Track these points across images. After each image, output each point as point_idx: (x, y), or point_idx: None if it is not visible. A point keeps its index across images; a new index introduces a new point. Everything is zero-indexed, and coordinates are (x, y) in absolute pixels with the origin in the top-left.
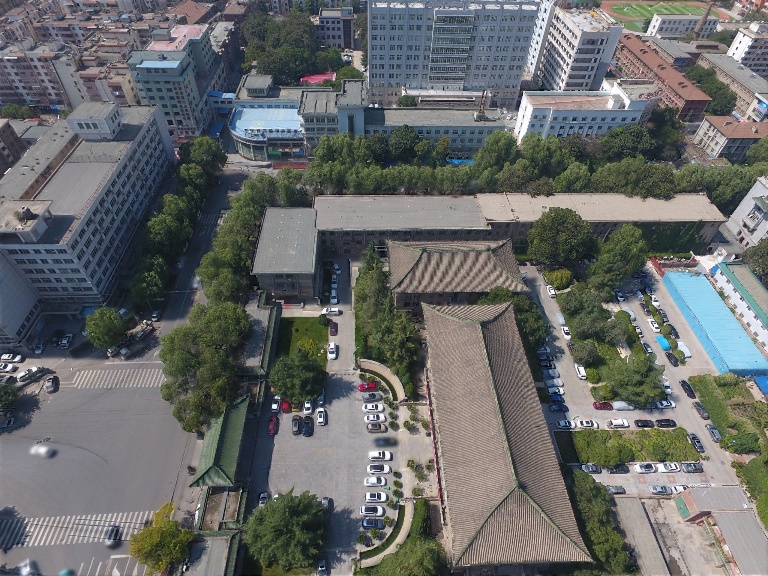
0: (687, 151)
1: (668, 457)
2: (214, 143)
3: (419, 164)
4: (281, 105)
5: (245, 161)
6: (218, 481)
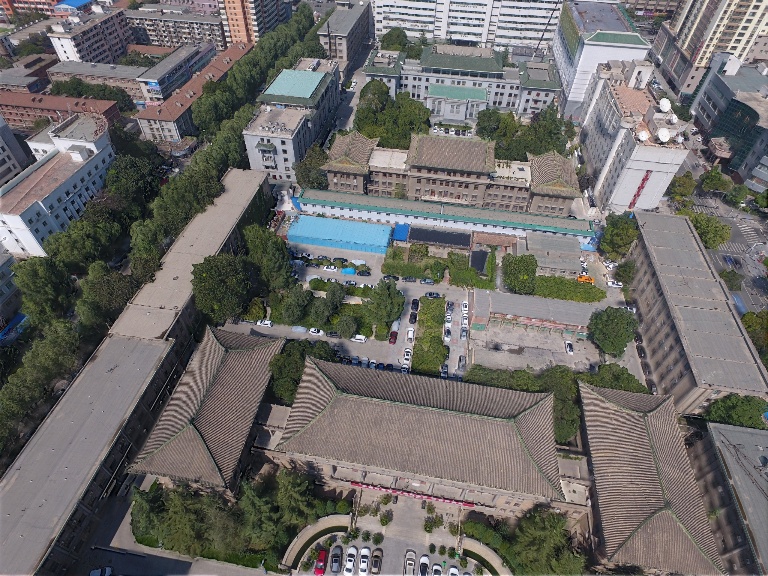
0: (159, 150)
1: None
2: None
3: None
4: None
5: None
6: None
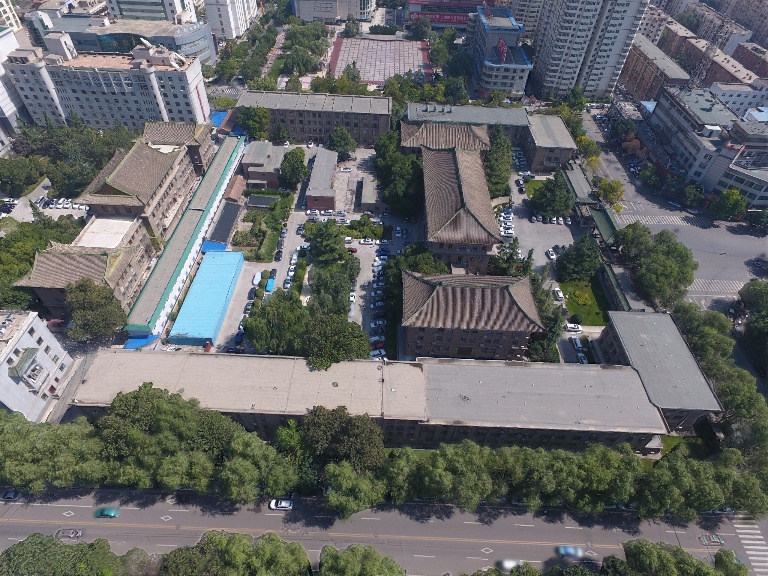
0: None
1: None
2: None
3: None
4: None
5: None
6: None
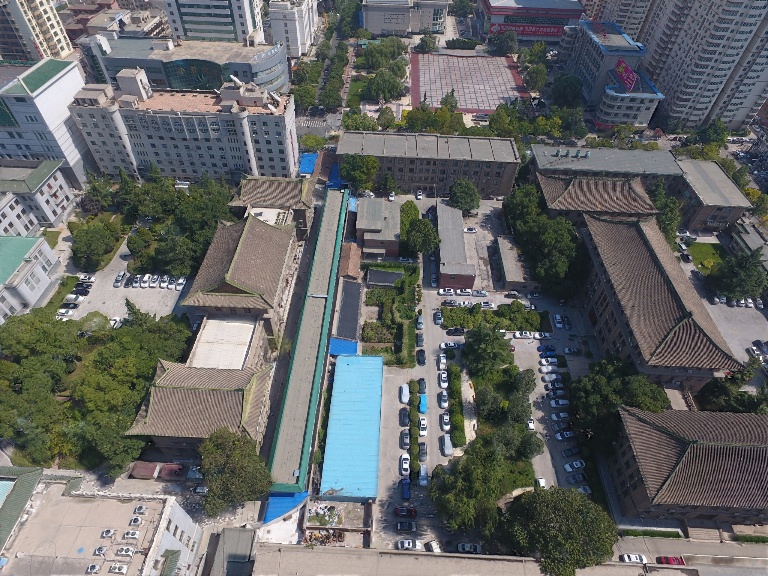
0: None
1: None
2: None
3: None
4: None
5: None
6: None
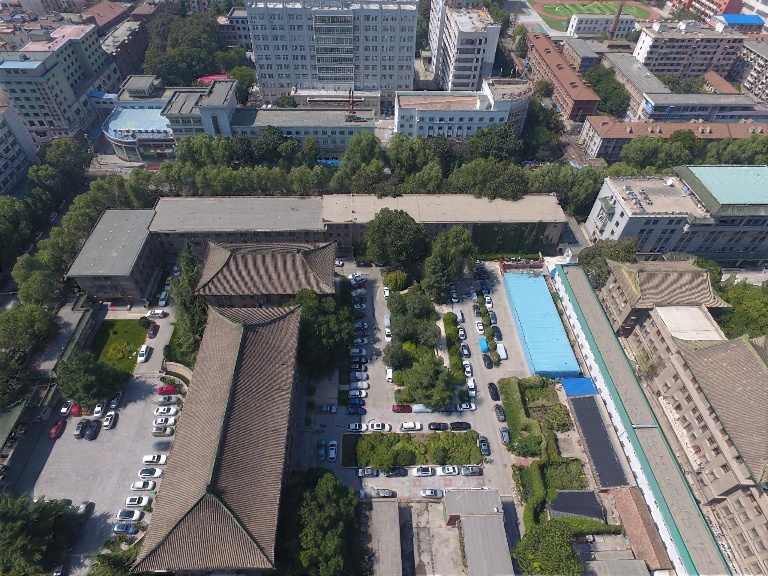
0: (567, 151)
1: (449, 460)
2: (73, 144)
3: (285, 165)
4: (162, 106)
5: (120, 162)
6: None
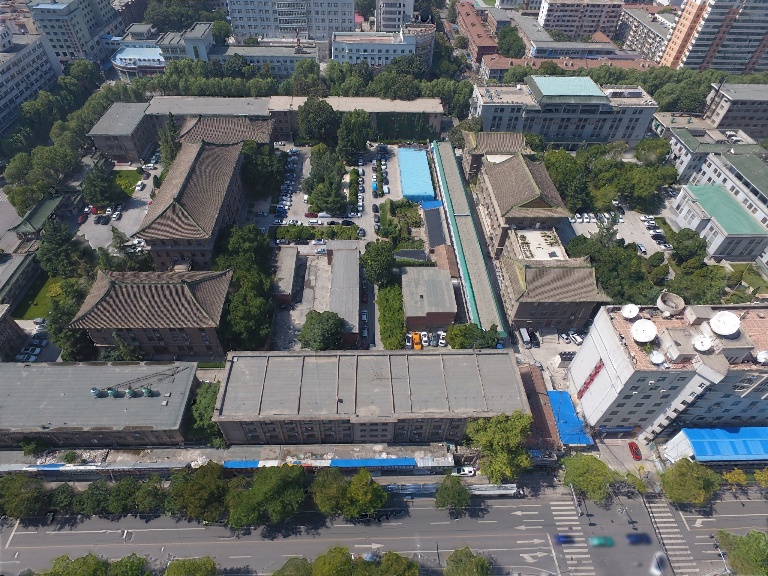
0: None
1: (336, 237)
2: (90, 64)
3: None
4: None
5: None
6: (27, 230)
